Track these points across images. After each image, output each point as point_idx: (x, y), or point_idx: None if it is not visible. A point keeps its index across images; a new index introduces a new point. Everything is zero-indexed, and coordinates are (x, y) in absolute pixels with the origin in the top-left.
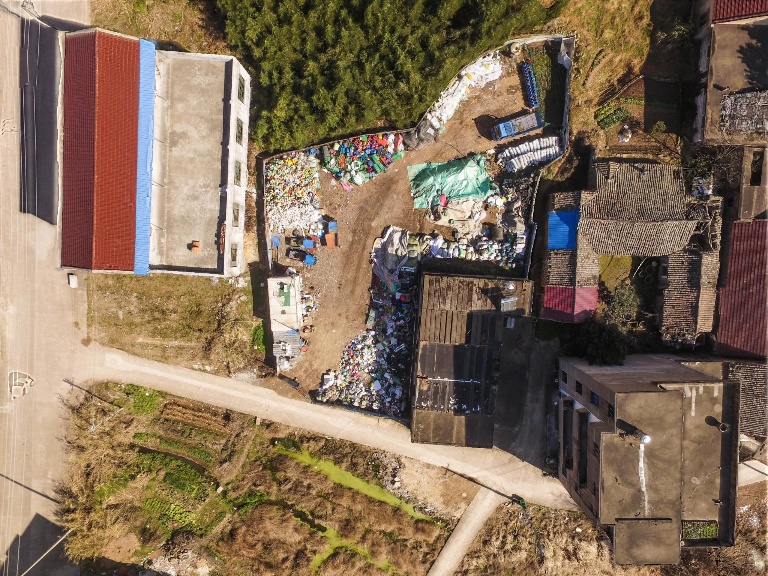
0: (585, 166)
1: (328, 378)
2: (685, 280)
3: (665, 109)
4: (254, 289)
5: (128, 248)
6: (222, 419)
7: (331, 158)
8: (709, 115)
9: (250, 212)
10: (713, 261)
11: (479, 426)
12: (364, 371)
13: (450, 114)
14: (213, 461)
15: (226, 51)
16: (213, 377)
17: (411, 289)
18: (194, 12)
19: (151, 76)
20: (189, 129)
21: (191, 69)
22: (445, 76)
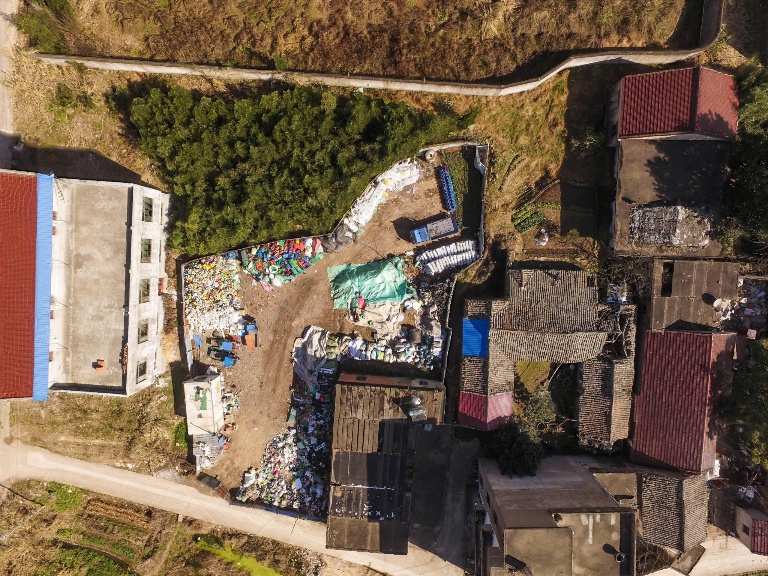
0: (502, 270)
1: (249, 477)
2: (599, 388)
3: (581, 213)
4: (175, 388)
5: (30, 371)
6: (145, 515)
7: (249, 262)
8: (618, 227)
9: (169, 315)
10: (627, 369)
11: (393, 533)
12: (285, 469)
13: (367, 218)
14: (136, 557)
15: (145, 158)
16: (135, 475)
17: (330, 390)
18: (114, 120)
19: (49, 208)
20: (93, 251)
21: (95, 194)
22: (354, 190)
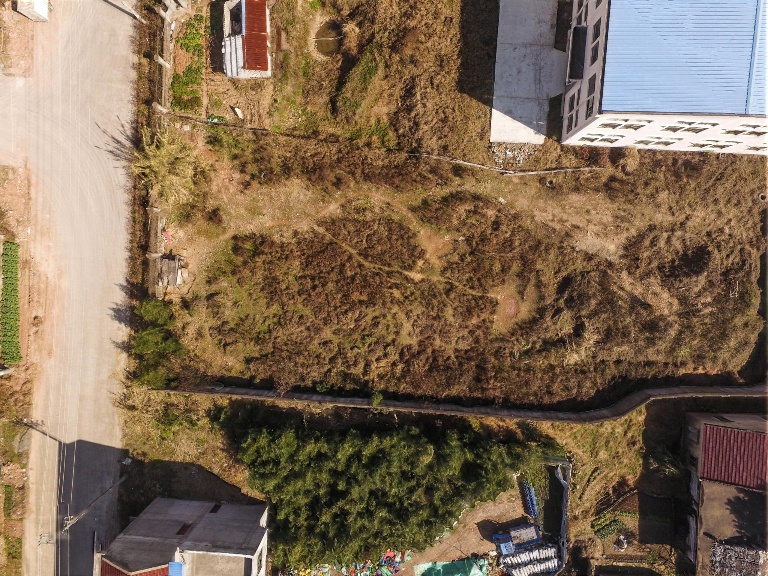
0: (583, 575)
1: None
2: None
3: (659, 522)
4: None
5: None
6: None
7: (342, 566)
8: (700, 559)
9: None
10: None
11: None
12: None
13: None
14: None
15: (245, 472)
16: None
17: None
18: (216, 437)
19: None
20: None
21: (214, 557)
22: None
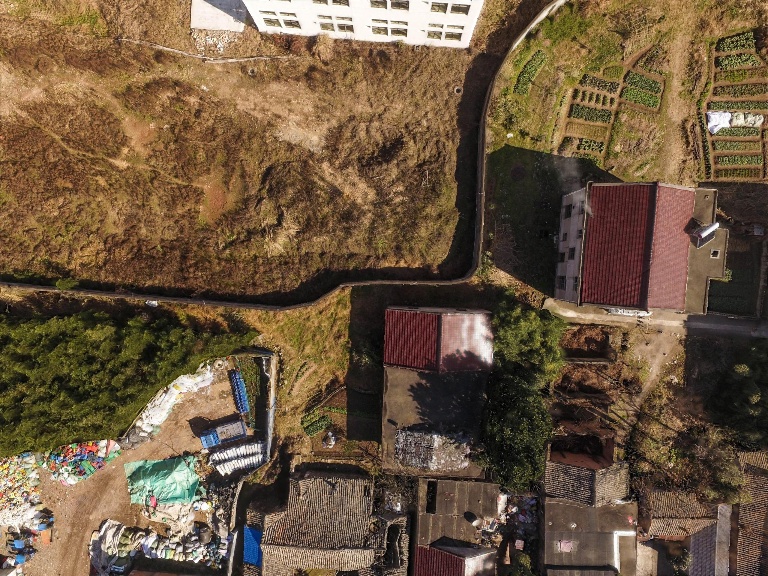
0: None
1: None
2: None
3: (366, 419)
4: None
5: None
6: None
7: (44, 461)
8: (385, 447)
9: None
10: None
11: None
12: None
13: (161, 420)
14: None
15: None
16: None
17: None
18: None
19: None
20: None
21: None
22: None
